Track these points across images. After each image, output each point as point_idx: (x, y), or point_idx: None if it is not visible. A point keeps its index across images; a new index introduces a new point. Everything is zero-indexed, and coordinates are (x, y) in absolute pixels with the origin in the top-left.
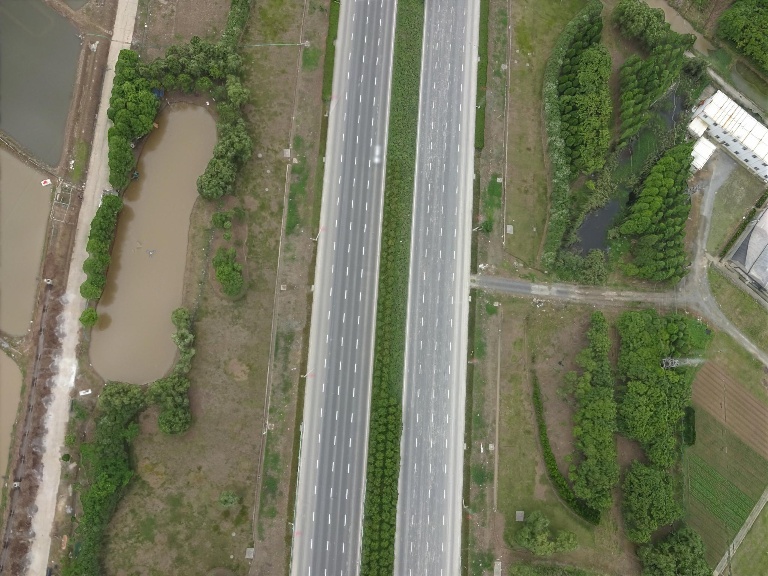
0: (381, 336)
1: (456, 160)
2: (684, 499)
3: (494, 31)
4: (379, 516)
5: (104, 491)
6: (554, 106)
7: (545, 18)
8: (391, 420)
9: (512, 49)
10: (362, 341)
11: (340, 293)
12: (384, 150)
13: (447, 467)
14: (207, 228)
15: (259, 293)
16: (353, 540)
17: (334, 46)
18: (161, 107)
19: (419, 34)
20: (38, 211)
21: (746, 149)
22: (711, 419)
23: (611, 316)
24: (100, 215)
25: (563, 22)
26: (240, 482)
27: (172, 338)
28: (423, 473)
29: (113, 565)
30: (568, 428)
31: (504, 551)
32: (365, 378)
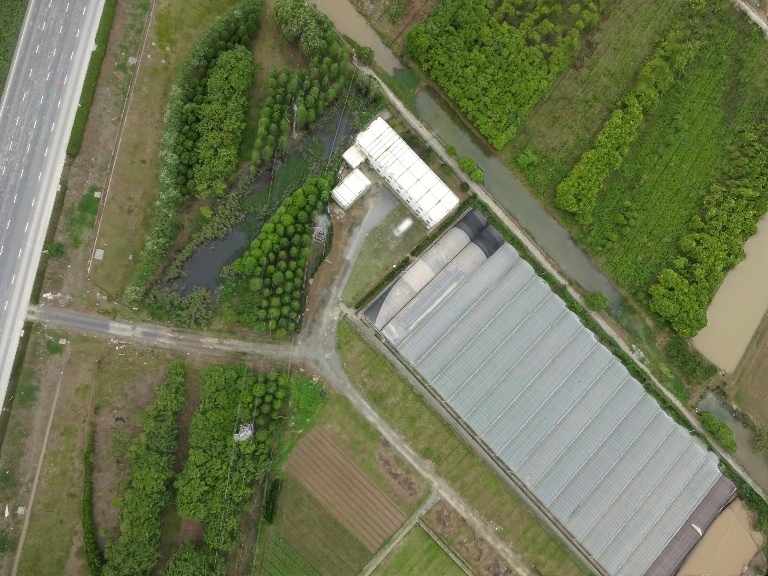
0: None
1: (40, 166)
2: None
3: (128, 16)
4: None
5: None
6: (174, 114)
7: (197, 8)
8: None
9: (148, 40)
10: None
11: None
12: None
13: None
14: None
15: None
16: None
17: None
18: None
19: (20, 9)
20: None
21: (402, 188)
22: (306, 494)
23: (206, 367)
24: None
25: None
26: None
27: None
28: None
29: None
30: None
31: None
32: None
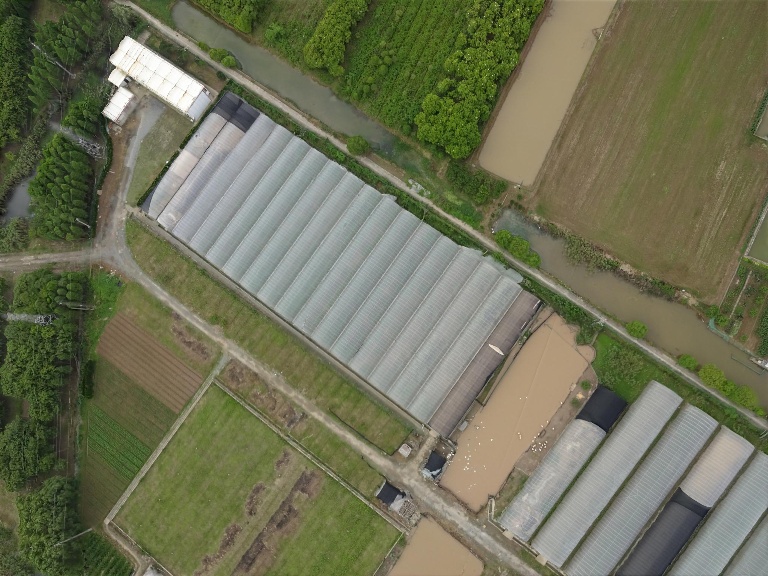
0: None
1: None
2: (81, 450)
3: None
4: None
5: None
6: None
7: None
8: None
9: None
10: None
11: None
12: None
13: None
14: None
15: None
16: None
17: None
18: None
19: None
20: None
21: None
22: (115, 371)
23: None
24: None
25: None
26: None
27: None
28: None
29: None
30: None
31: None
32: None
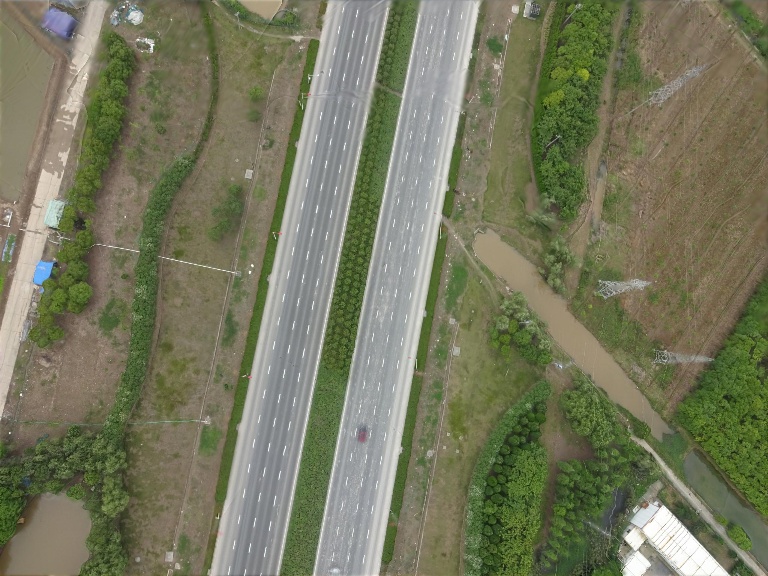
0: None
1: (359, 574)
2: None
3: (425, 409)
4: None
5: None
6: (477, 517)
7: (485, 393)
8: None
9: (442, 430)
10: None
11: None
12: (279, 561)
13: None
14: None
15: None
16: None
17: (237, 431)
18: (29, 499)
19: (336, 420)
20: None
21: (682, 574)
22: None
23: None
24: None
25: (505, 399)
26: None
27: None
28: None
29: None
30: None
31: None
32: None
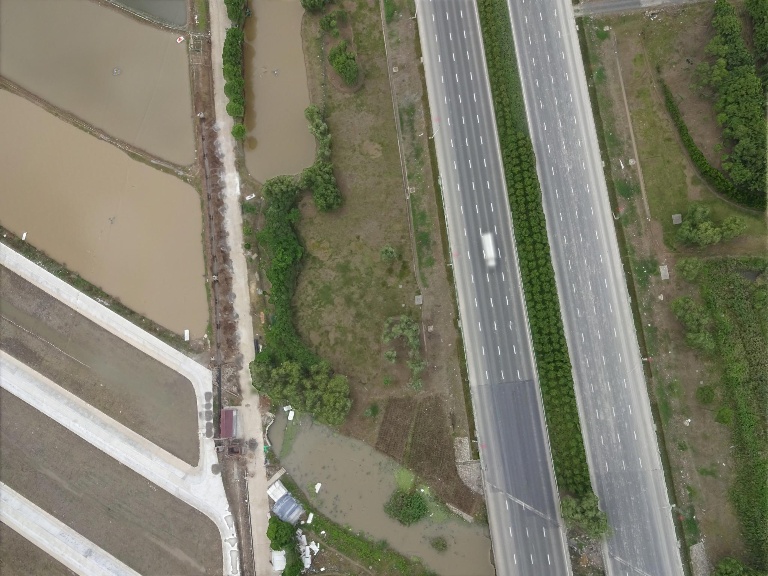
0: (496, 83)
1: None
2: None
3: None
4: (530, 238)
5: (283, 263)
6: None
7: None
8: (522, 151)
9: None
10: (479, 93)
11: (448, 57)
12: None
13: (589, 186)
14: (317, 38)
15: (375, 80)
16: (511, 268)
17: None
18: None
19: None
20: (180, 66)
21: None
22: None
23: (737, 6)
24: (227, 43)
25: None
26: (396, 242)
27: (309, 129)
28: (566, 197)
29: (305, 329)
30: (712, 125)
31: (667, 255)
32: (489, 125)
